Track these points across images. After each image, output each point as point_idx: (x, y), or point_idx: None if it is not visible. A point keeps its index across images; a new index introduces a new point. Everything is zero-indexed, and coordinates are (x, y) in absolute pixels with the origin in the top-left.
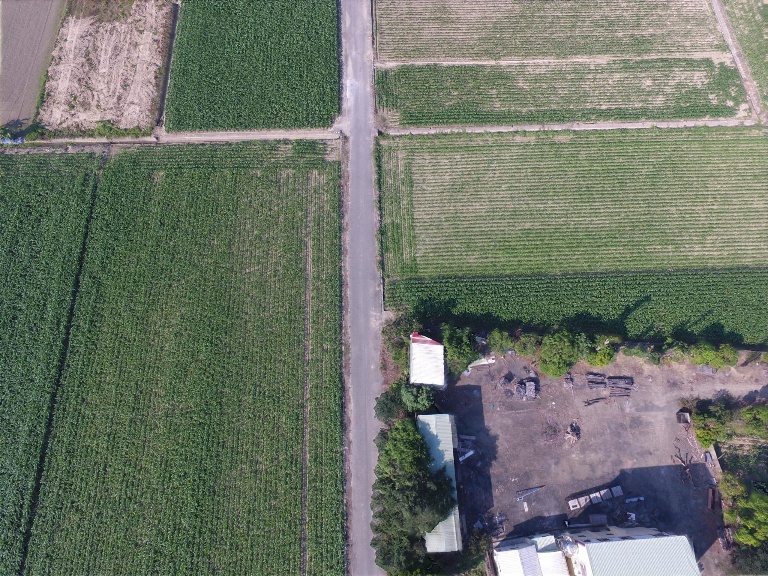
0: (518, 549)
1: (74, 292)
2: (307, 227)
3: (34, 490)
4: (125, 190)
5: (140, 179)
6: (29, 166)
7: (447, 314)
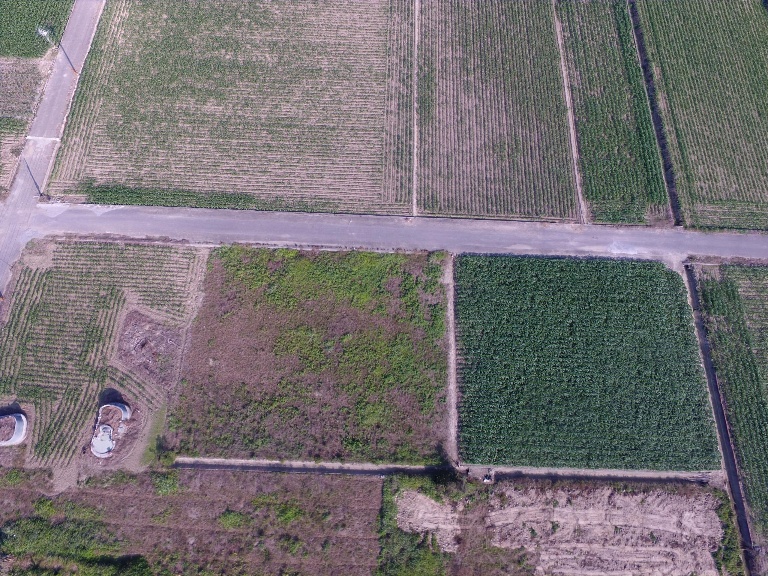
0: None
1: None
2: None
3: None
4: None
5: None
6: None
7: None
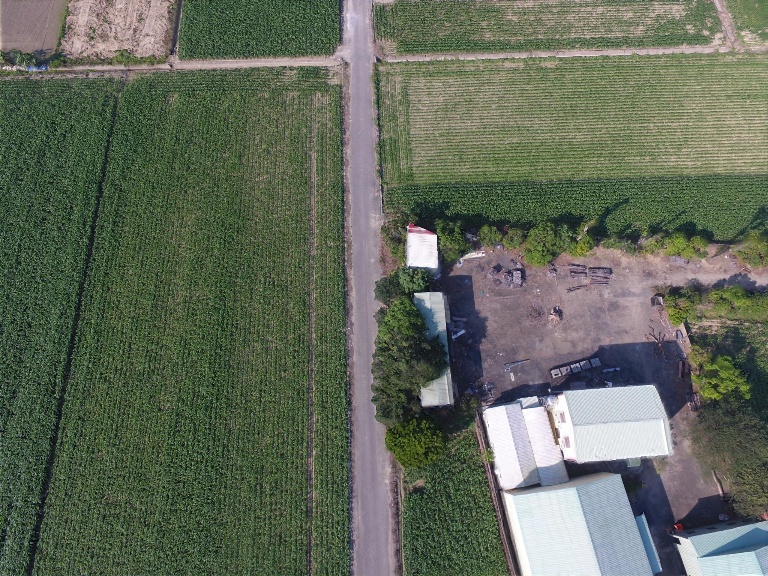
0: (504, 405)
1: (98, 197)
2: (311, 142)
3: (66, 363)
4: (143, 109)
5: (156, 100)
6: (53, 89)
7: (441, 215)
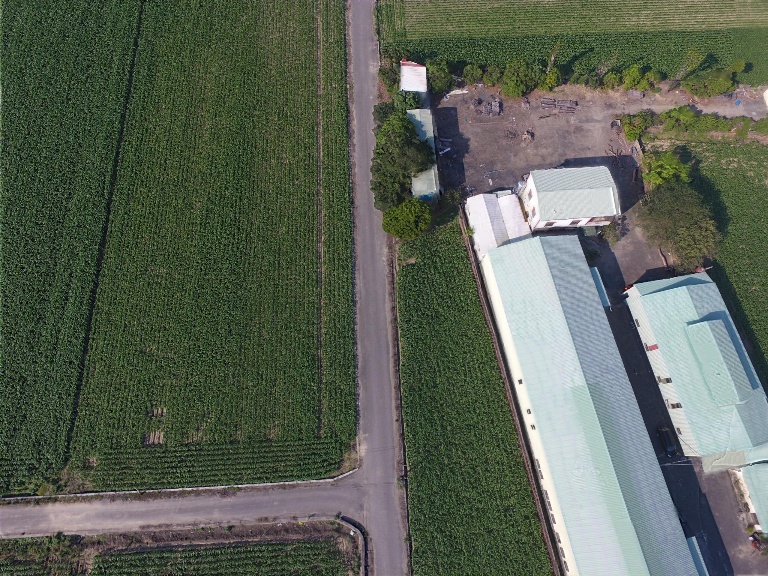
0: None
1: (134, 49)
2: (317, 8)
3: (112, 173)
4: None
5: None
6: None
7: None
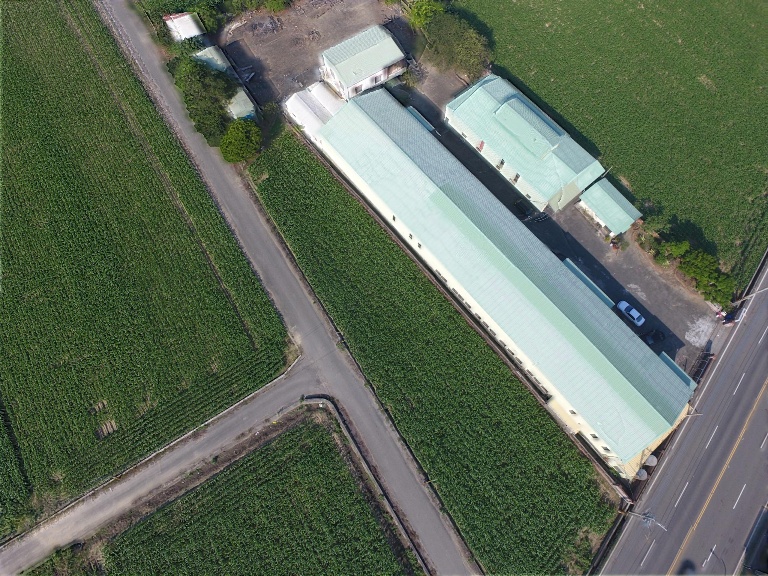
0: (295, 93)
1: None
2: (73, 7)
3: None
4: None
5: None
6: None
7: None
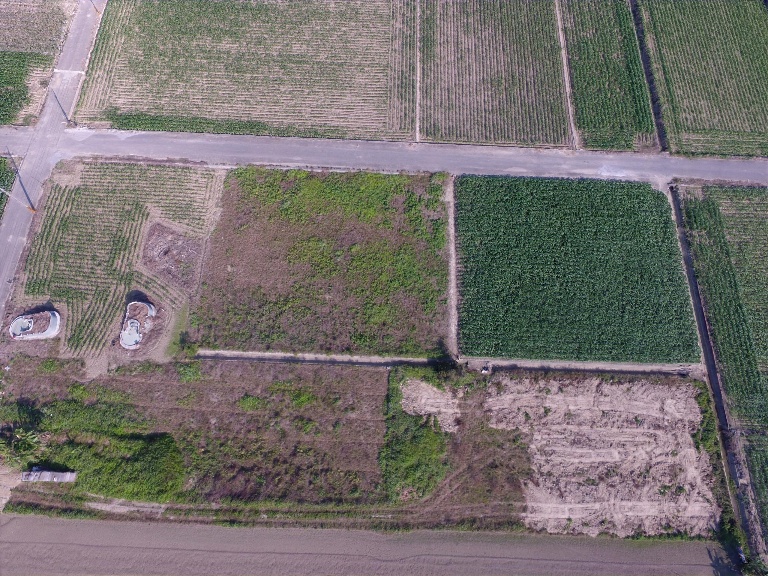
0: None
1: None
2: None
3: None
4: None
5: None
6: None
7: None
